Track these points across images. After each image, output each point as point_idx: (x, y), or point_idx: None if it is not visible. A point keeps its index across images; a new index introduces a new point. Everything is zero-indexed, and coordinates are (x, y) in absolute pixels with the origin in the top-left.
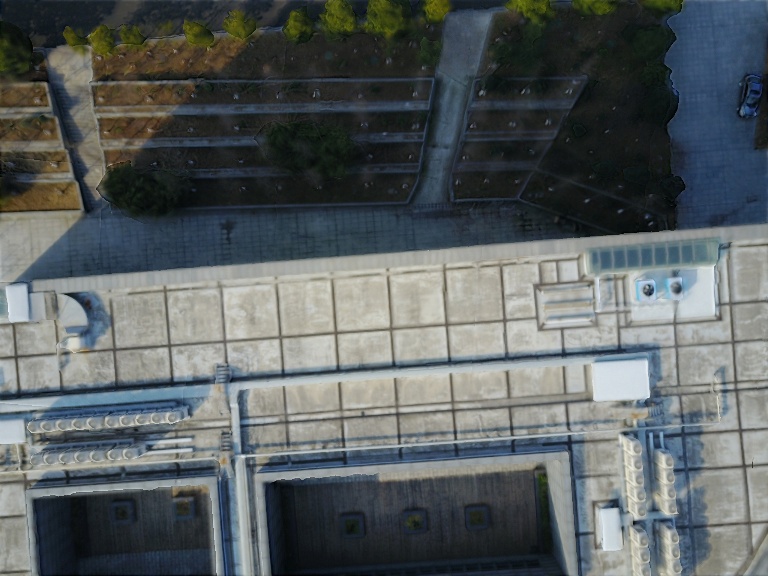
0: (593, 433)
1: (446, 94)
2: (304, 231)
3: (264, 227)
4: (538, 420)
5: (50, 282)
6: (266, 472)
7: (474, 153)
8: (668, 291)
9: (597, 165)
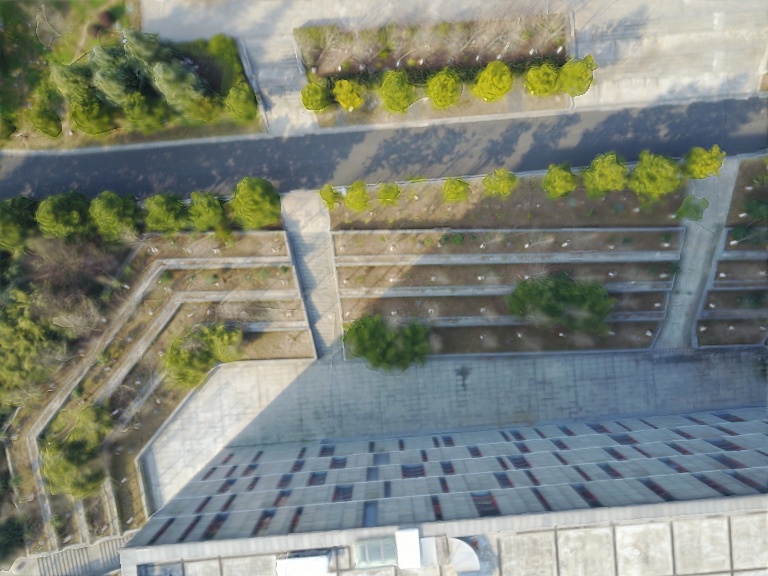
0: None
1: (694, 241)
2: (542, 377)
3: (501, 373)
4: None
5: (441, 526)
6: None
7: (721, 300)
8: None
9: None
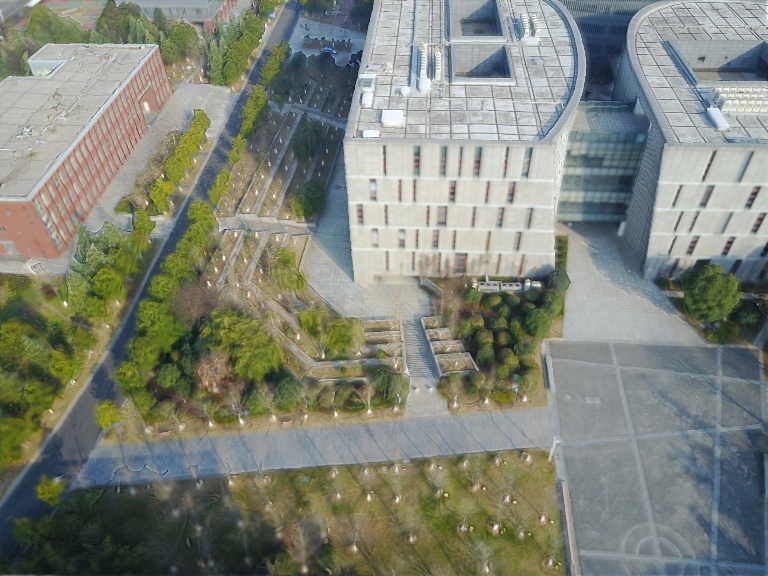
0: None
1: None
2: None
3: (342, 175)
4: (438, 2)
5: (360, 70)
6: (450, 36)
7: None
8: None
9: (346, 70)
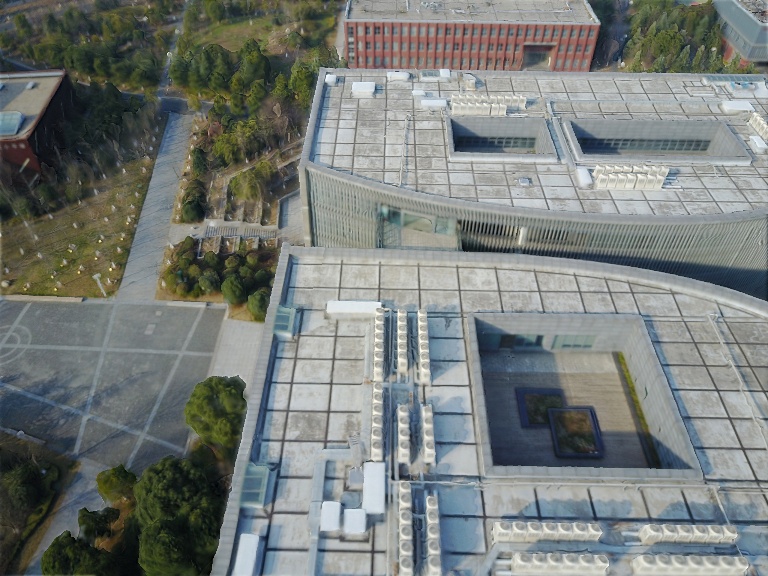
0: (733, 122)
1: None
2: None
3: None
4: None
5: None
6: None
7: None
8: (747, 84)
9: None
